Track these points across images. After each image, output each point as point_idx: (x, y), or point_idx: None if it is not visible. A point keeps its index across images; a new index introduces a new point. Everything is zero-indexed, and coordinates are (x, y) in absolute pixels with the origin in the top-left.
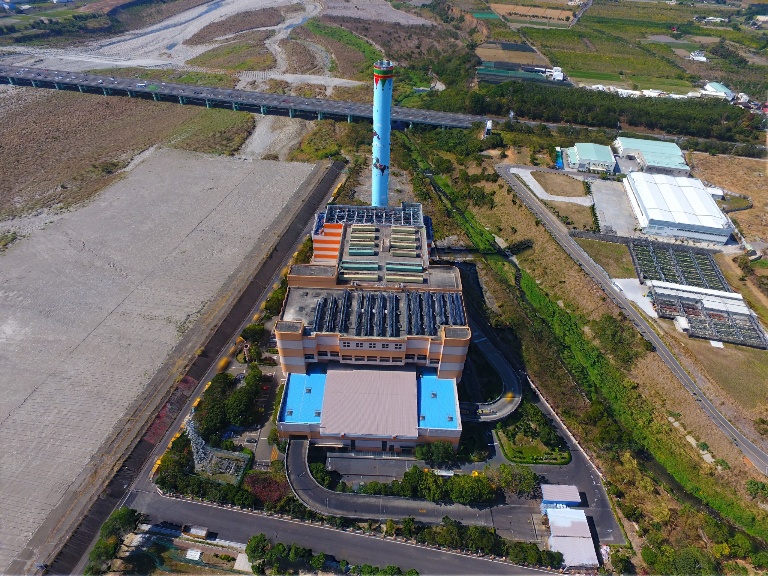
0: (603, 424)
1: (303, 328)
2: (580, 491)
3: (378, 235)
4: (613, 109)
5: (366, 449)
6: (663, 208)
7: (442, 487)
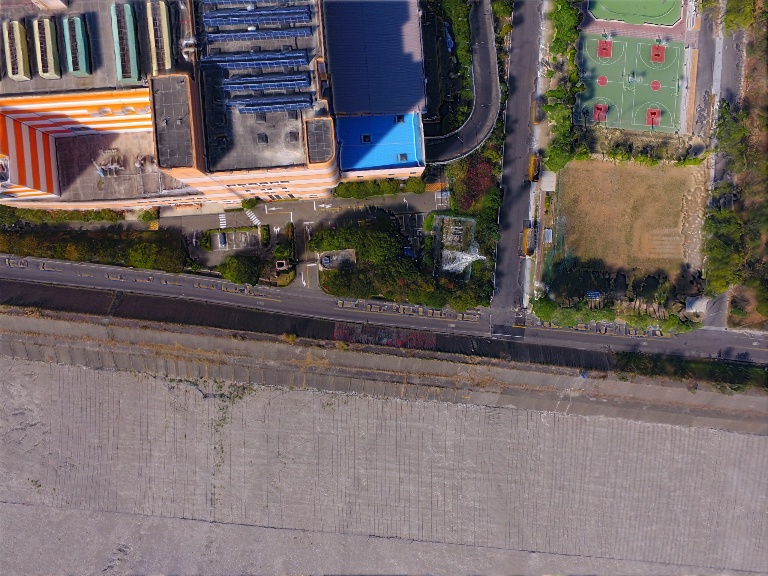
0: None
1: None
2: None
3: (6, 21)
4: None
5: None
6: None
7: None
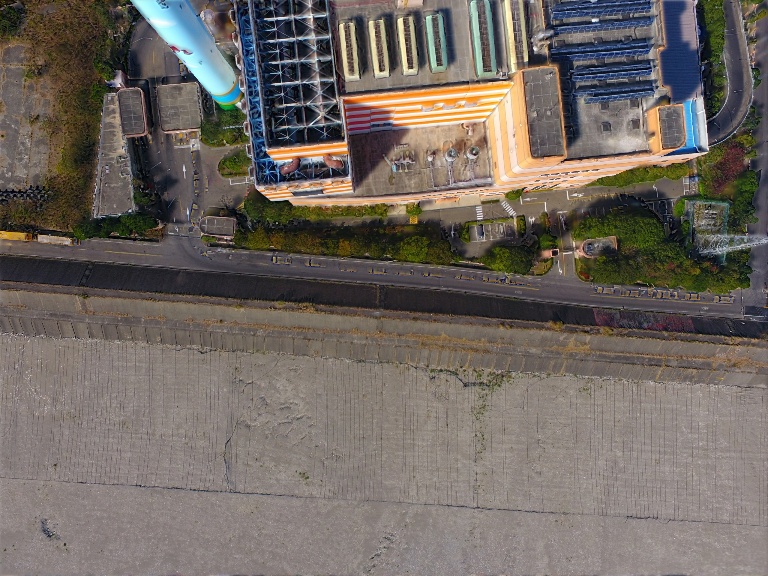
0: None
1: None
2: None
3: (364, 20)
4: None
5: None
6: None
7: None
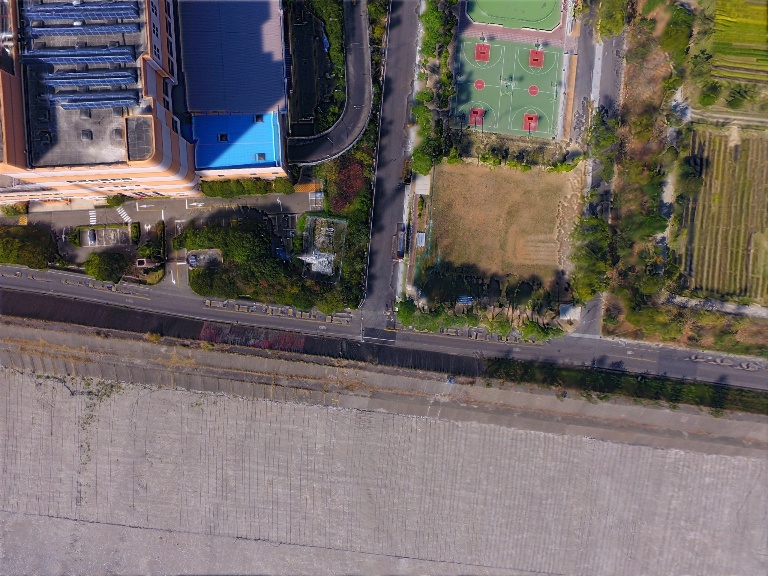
0: None
1: None
2: None
3: None
4: None
5: None
6: None
7: None
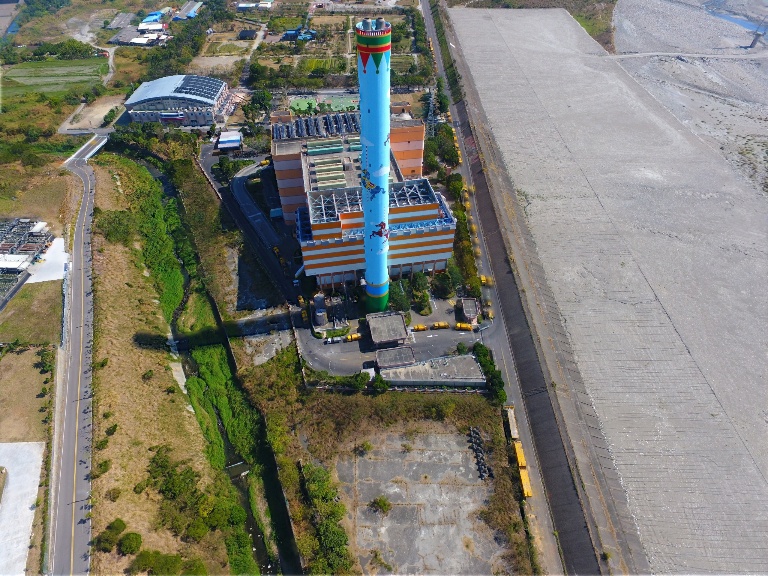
0: None
1: None
2: (215, 156)
3: None
4: None
5: None
6: None
7: None
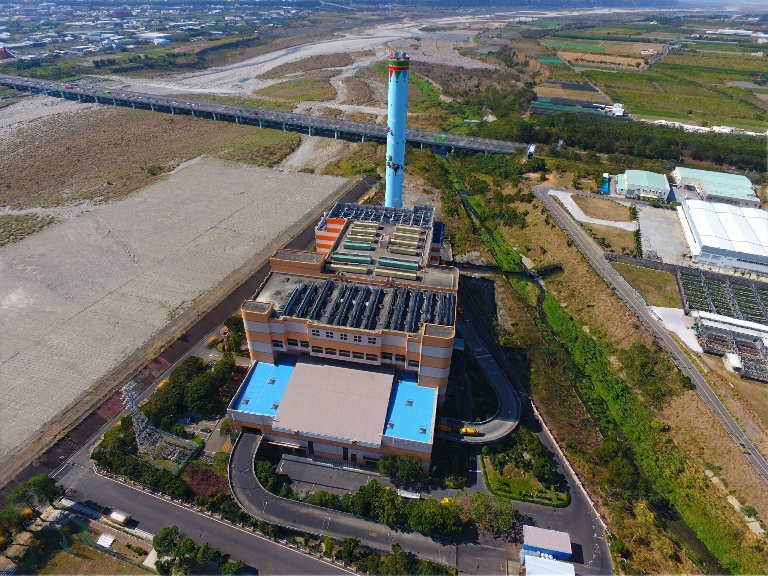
0: (615, 465)
1: (272, 310)
2: (575, 542)
3: (380, 232)
4: (675, 142)
5: (326, 456)
6: (721, 236)
7: (400, 509)
